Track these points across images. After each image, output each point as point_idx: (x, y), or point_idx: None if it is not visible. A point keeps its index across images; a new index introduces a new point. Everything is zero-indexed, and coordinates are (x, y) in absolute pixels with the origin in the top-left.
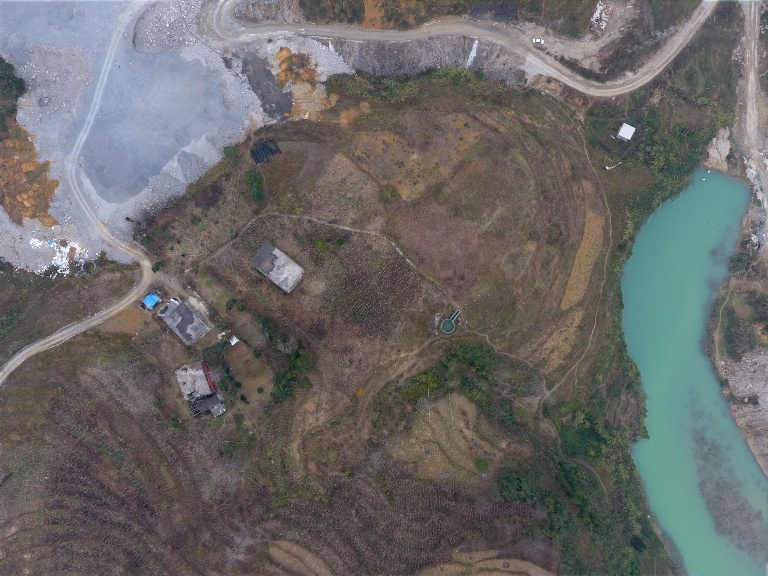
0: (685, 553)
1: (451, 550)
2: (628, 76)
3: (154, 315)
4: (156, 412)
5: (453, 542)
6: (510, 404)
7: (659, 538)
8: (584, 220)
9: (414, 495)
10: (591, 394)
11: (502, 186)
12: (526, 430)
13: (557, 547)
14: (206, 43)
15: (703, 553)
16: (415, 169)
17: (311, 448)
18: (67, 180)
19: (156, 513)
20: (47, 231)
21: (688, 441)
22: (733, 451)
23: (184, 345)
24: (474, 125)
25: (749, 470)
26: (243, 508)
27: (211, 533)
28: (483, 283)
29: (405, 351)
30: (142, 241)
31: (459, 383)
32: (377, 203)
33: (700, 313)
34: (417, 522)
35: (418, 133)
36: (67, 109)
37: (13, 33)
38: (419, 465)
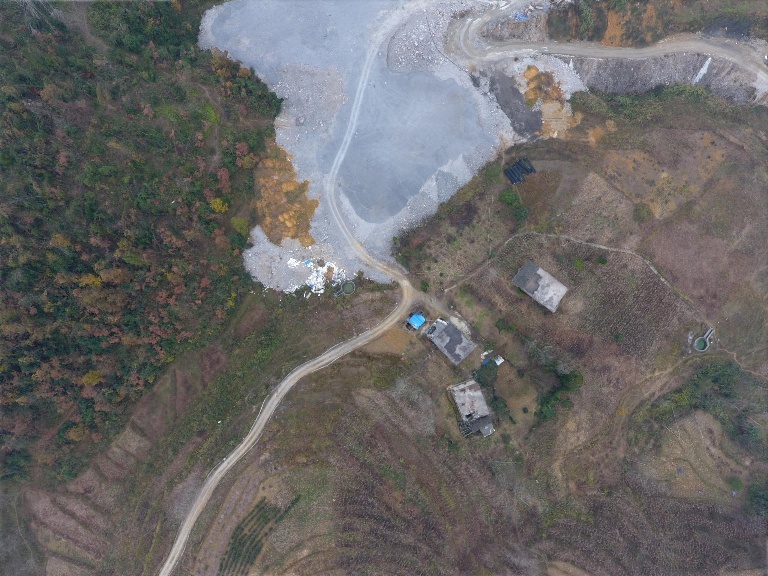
0: None
1: (718, 569)
2: None
3: (417, 335)
4: (431, 433)
5: (719, 561)
6: None
7: None
8: None
9: (671, 514)
10: None
11: (750, 204)
12: (764, 447)
13: None
14: (454, 62)
15: None
16: (666, 187)
17: (571, 467)
18: (326, 200)
19: (443, 535)
20: (305, 251)
21: None
22: None
23: (449, 365)
24: (720, 143)
25: None
26: (516, 528)
27: (490, 554)
28: (734, 301)
29: (659, 370)
30: (402, 261)
31: (700, 400)
32: (632, 222)
33: None
34: (678, 541)
35: (666, 151)
36: (324, 129)
37: (268, 53)
38: (672, 483)
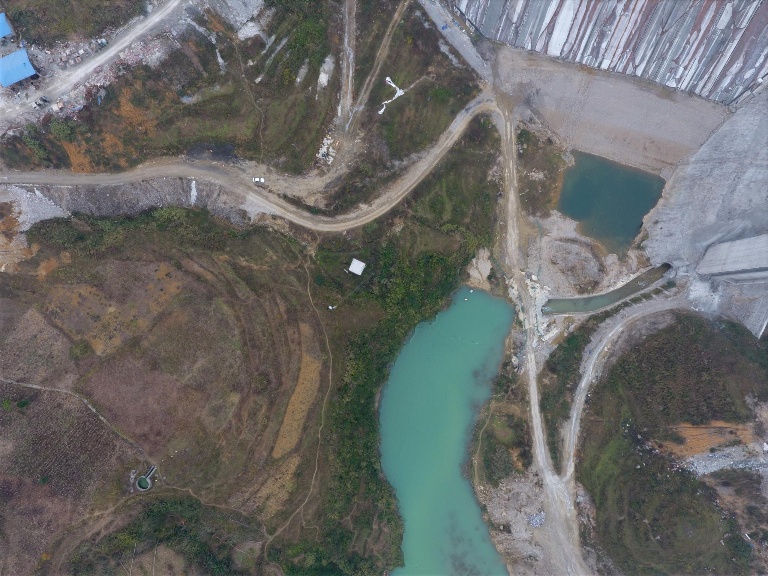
0: None
1: None
2: (362, 208)
3: None
4: None
5: None
6: (230, 550)
7: None
8: (299, 365)
9: None
10: (328, 531)
11: (203, 338)
12: None
13: None
14: None
15: None
16: (112, 322)
17: None
18: None
19: None
20: None
21: (447, 567)
22: None
23: None
24: (176, 275)
25: None
26: None
27: None
28: (181, 438)
29: (99, 509)
30: None
31: (171, 533)
32: (68, 360)
33: (461, 436)
34: None
35: (117, 284)
36: None
37: None
38: None
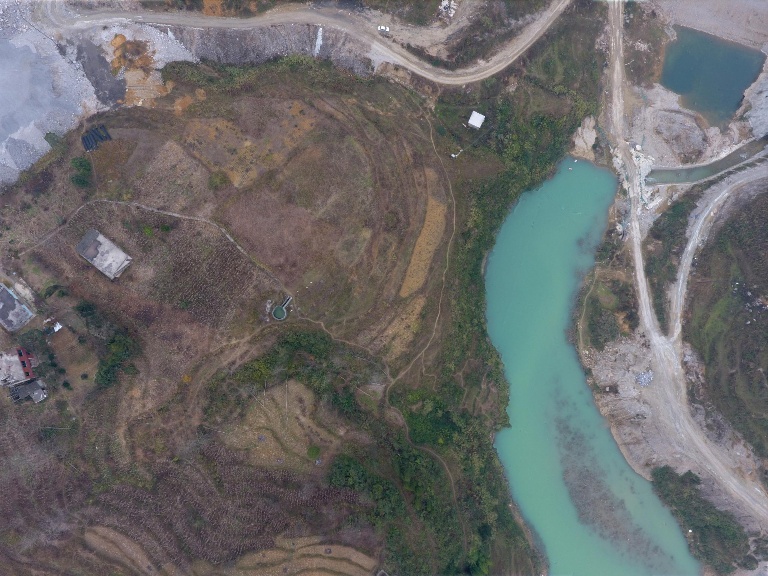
0: (547, 542)
1: (274, 536)
2: (480, 64)
3: None
4: None
5: (277, 528)
6: (354, 392)
7: (521, 527)
8: (426, 208)
9: (243, 482)
10: (444, 382)
11: (336, 173)
12: (368, 418)
13: (380, 533)
14: (40, 30)
15: (565, 542)
16: (248, 156)
17: (138, 435)
18: None
19: None
20: None
21: (552, 430)
22: (598, 440)
23: (8, 331)
24: (310, 112)
25: (612, 459)
26: (62, 494)
27: (26, 518)
28: (316, 270)
29: (236, 338)
30: None
31: (299, 370)
32: (207, 190)
33: (565, 302)
34: (244, 508)
35: (252, 120)
36: None
37: None
38: (251, 452)
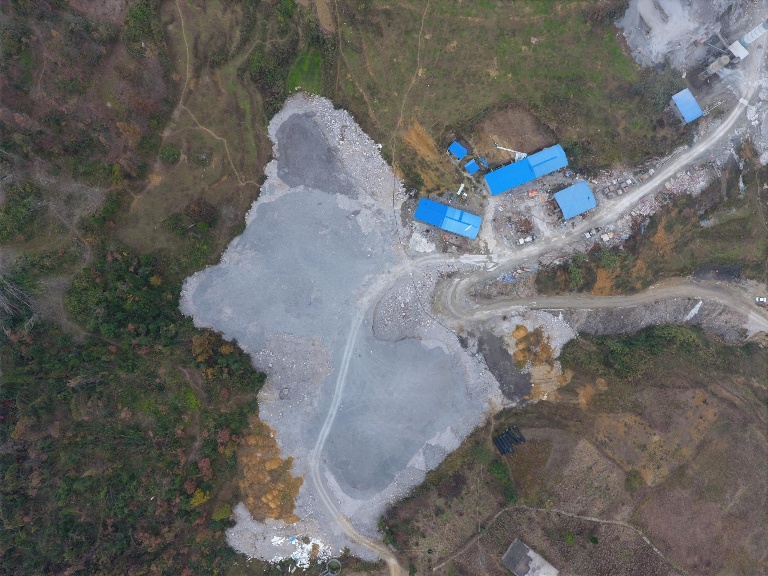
0: None
1: None
2: None
3: None
4: None
5: None
6: None
7: None
8: None
9: None
10: None
11: (743, 465)
12: None
13: None
14: (441, 322)
15: None
16: (657, 452)
17: None
18: (311, 477)
19: None
20: (290, 529)
21: None
22: None
23: None
24: (712, 401)
25: None
26: None
27: None
28: (729, 568)
29: None
30: (389, 539)
31: None
32: (624, 492)
33: None
34: None
35: (658, 412)
36: (309, 402)
37: (251, 322)
38: None
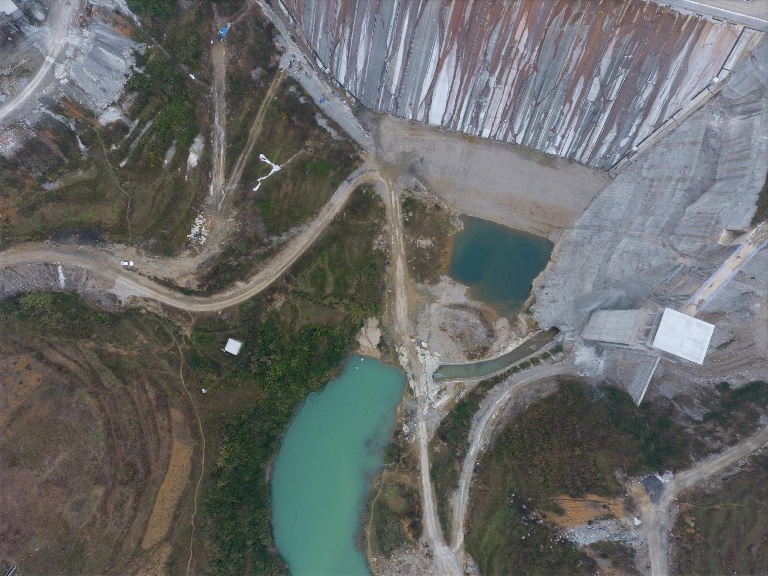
0: None
1: None
2: (239, 286)
3: None
4: None
5: None
6: None
7: None
8: (170, 452)
9: None
10: None
11: (64, 431)
12: None
13: None
14: None
15: None
16: None
17: None
18: None
19: None
20: None
21: None
22: None
23: None
24: (37, 366)
25: None
26: None
27: None
28: (42, 535)
29: None
30: None
31: None
32: None
33: (354, 506)
34: None
35: None
36: None
37: None
38: None
